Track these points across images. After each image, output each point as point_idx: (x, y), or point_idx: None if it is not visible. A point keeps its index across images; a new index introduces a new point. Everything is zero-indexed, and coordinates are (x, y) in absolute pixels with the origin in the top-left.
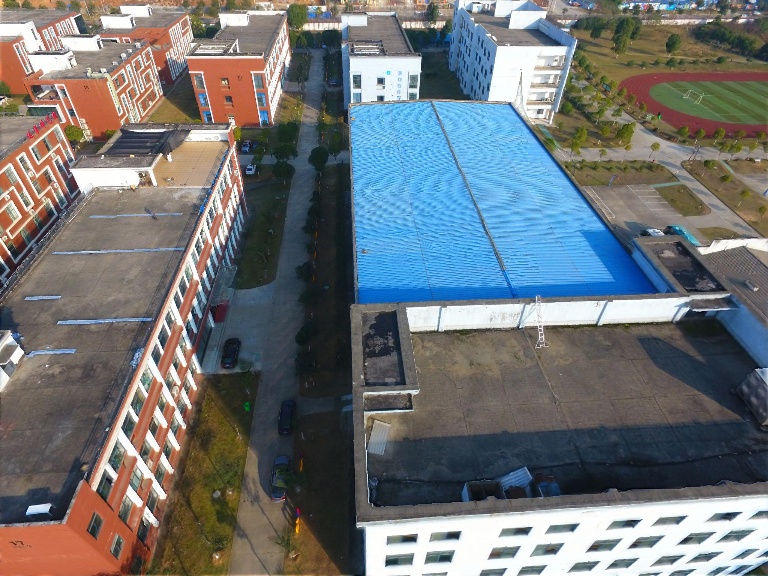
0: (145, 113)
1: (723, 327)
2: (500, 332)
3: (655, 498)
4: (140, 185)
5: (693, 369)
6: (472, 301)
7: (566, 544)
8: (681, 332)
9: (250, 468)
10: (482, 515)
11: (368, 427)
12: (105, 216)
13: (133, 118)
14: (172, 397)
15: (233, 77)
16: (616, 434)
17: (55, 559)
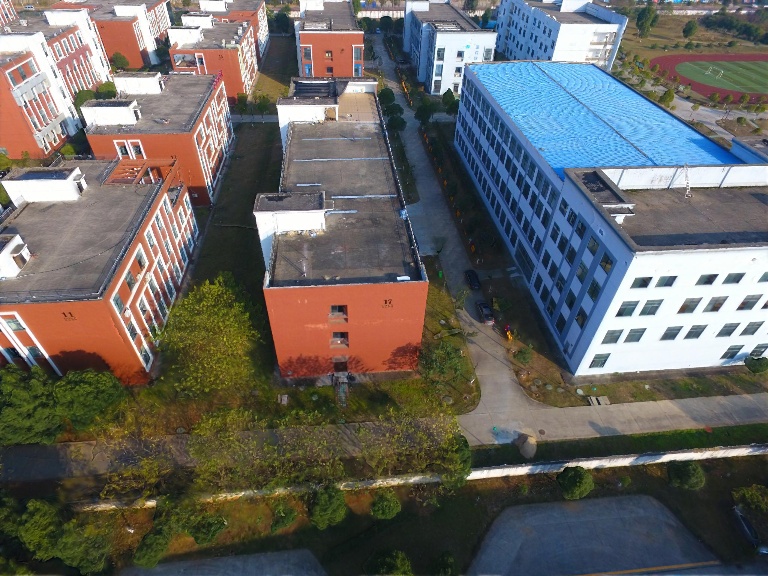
0: (252, 83)
1: None
2: (658, 190)
3: None
4: (325, 120)
5: None
6: (643, 166)
7: (729, 298)
8: None
9: None
10: (703, 251)
11: (600, 231)
12: (314, 139)
13: (248, 86)
14: None
15: (336, 50)
16: (755, 234)
17: (395, 323)
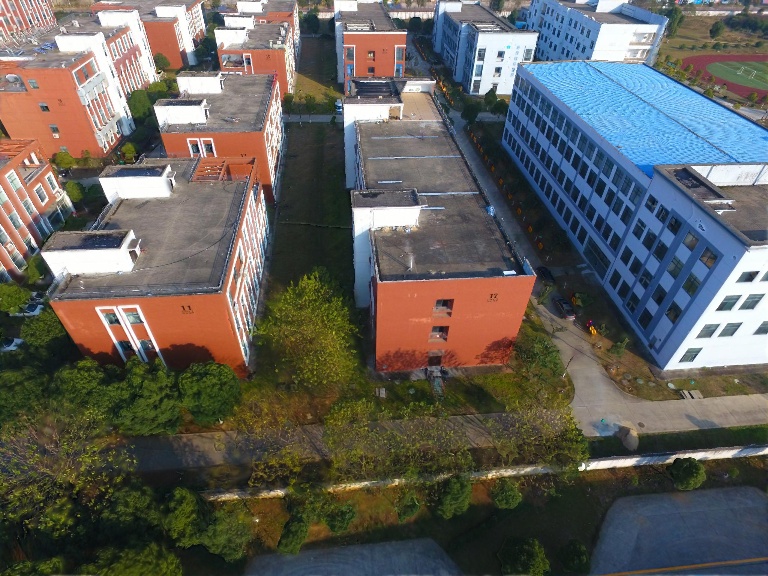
0: None
1: None
2: (743, 187)
3: None
4: (389, 119)
5: None
6: (730, 163)
7: None
8: None
9: None
10: None
11: (699, 226)
12: (382, 138)
13: (290, 86)
14: None
15: (379, 50)
16: None
17: (496, 317)
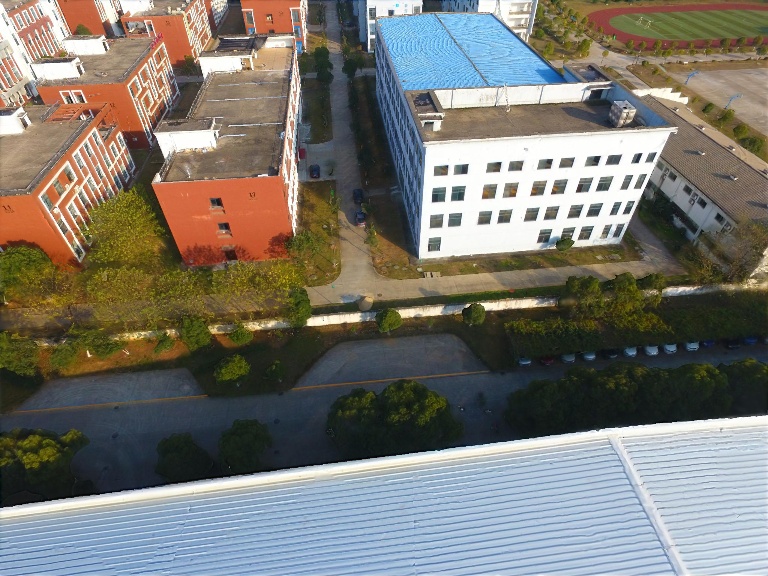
0: (203, 48)
1: (609, 102)
2: (485, 108)
3: (554, 133)
4: (242, 70)
5: (588, 115)
6: (469, 87)
7: (519, 184)
8: (586, 105)
9: (341, 217)
10: (477, 141)
11: None
12: (228, 85)
13: (198, 50)
14: (293, 175)
15: (276, 13)
16: None
17: (264, 214)
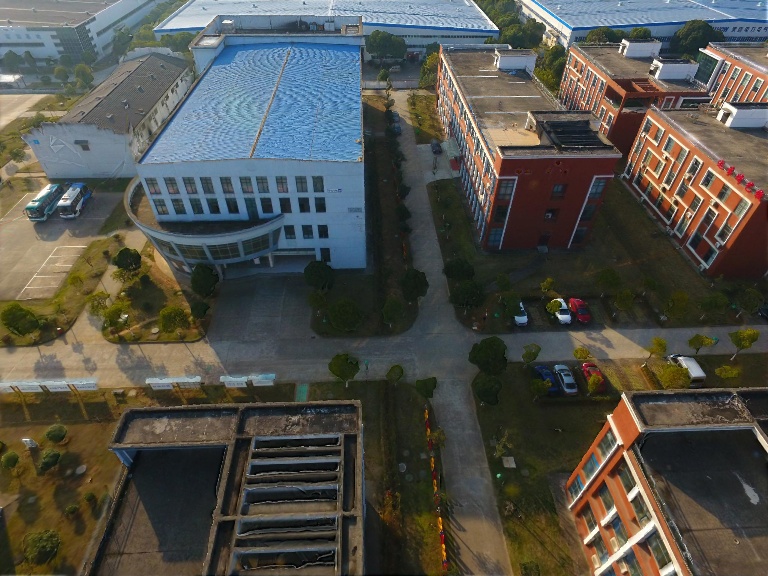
0: None
1: None
2: None
3: None
4: None
5: None
6: (314, 34)
7: None
8: None
9: (409, 121)
10: None
11: None
12: None
13: None
14: None
15: None
16: None
17: None
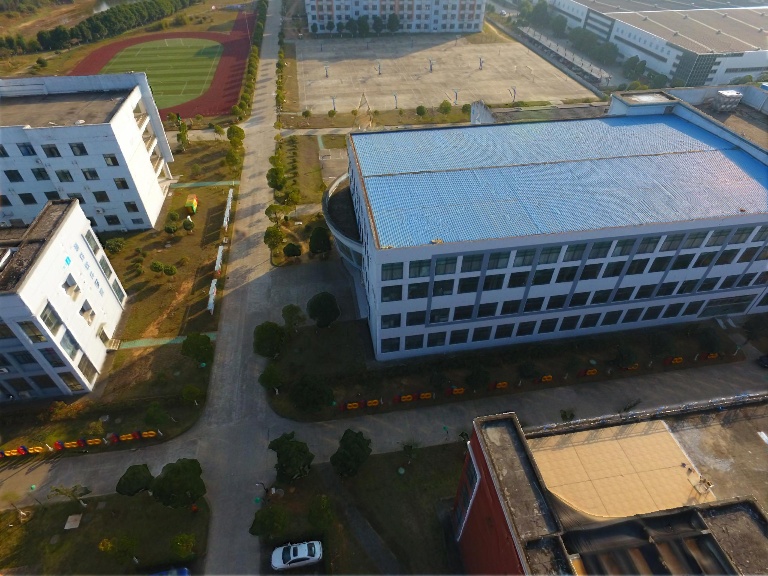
0: None
1: None
2: None
3: None
4: None
5: None
6: None
7: None
8: None
9: None
10: None
11: None
12: None
13: None
14: None
15: None
16: None
17: None
